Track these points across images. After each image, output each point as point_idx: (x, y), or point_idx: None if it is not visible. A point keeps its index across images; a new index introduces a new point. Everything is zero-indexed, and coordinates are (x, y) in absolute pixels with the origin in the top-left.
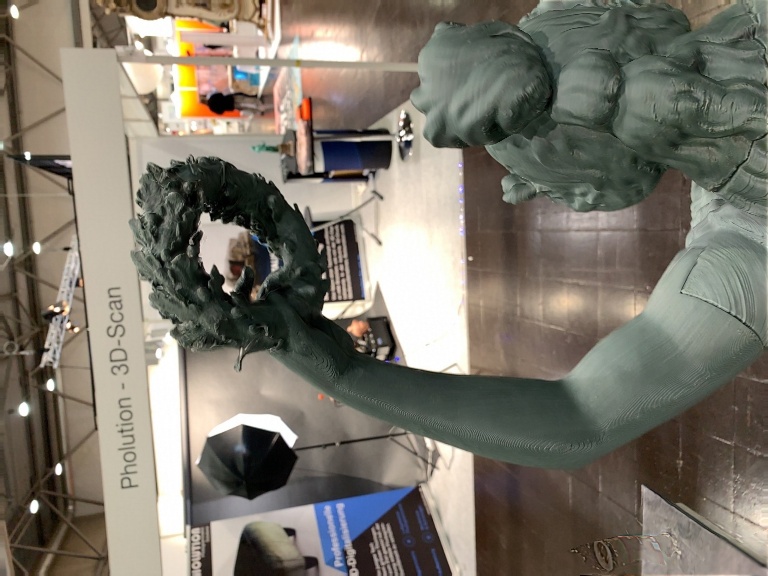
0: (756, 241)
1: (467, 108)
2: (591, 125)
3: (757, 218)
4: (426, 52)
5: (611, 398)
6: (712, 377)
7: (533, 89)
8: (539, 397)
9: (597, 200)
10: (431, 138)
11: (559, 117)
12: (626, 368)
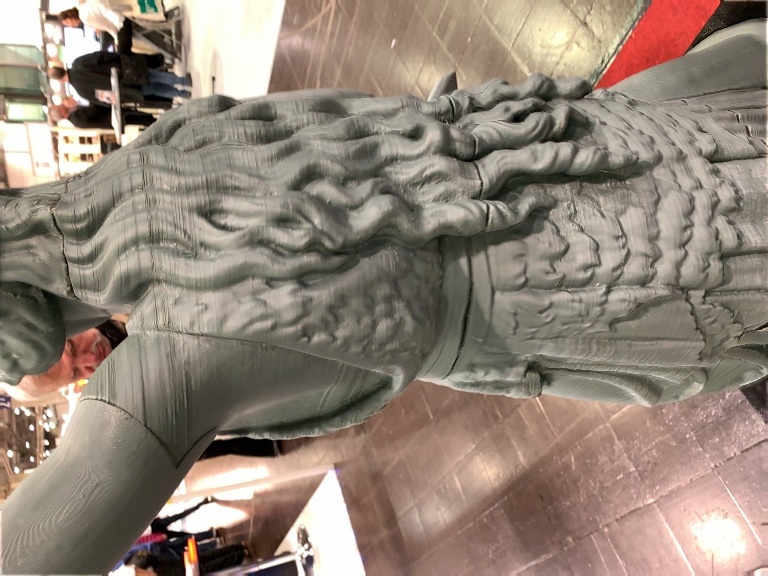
0: (132, 333)
1: None
2: None
3: None
4: None
5: None
6: (102, 482)
7: None
8: None
9: (1, 349)
10: None
11: None
12: (7, 505)
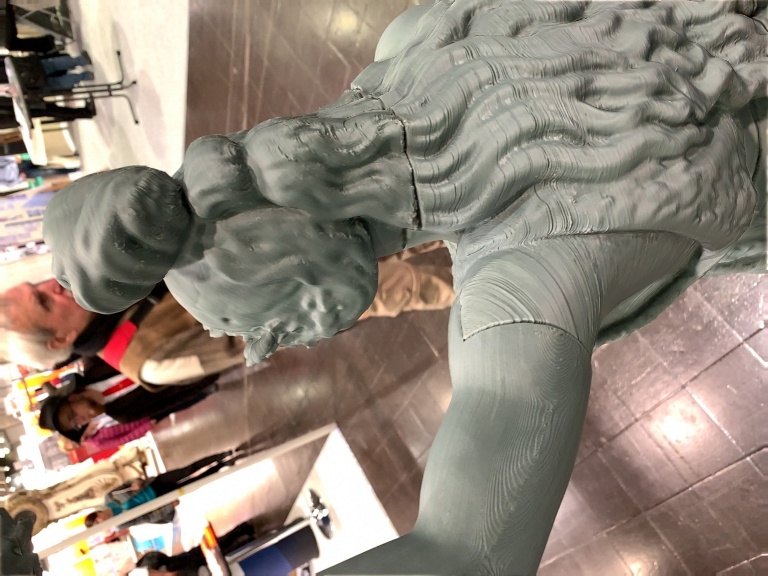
0: (494, 251)
1: (89, 233)
2: (231, 194)
3: (480, 232)
4: (42, 218)
5: (464, 502)
6: (556, 406)
7: (147, 182)
8: (378, 559)
9: (328, 302)
10: (82, 297)
11: (200, 206)
12: (458, 453)
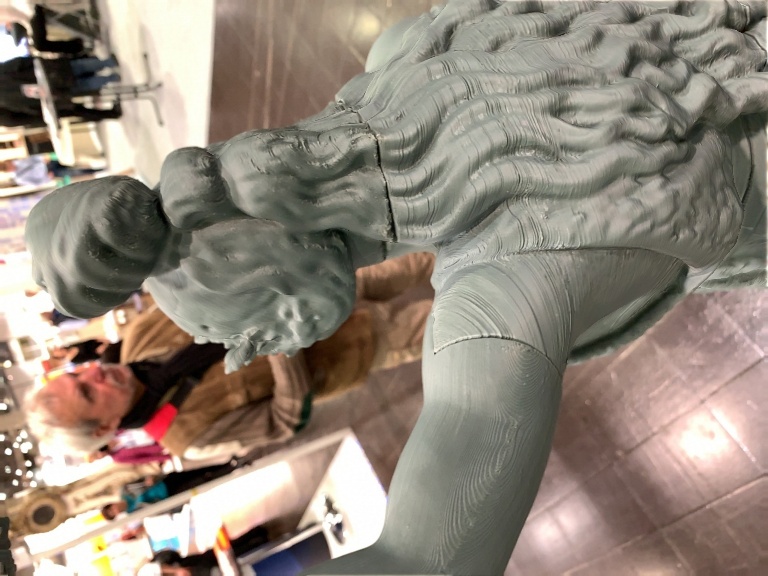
0: (468, 265)
1: (64, 241)
2: (204, 205)
3: (455, 246)
4: None
5: (424, 516)
6: (521, 423)
7: (122, 193)
8: (336, 569)
9: (304, 312)
10: (59, 303)
11: (175, 216)
12: (421, 467)
